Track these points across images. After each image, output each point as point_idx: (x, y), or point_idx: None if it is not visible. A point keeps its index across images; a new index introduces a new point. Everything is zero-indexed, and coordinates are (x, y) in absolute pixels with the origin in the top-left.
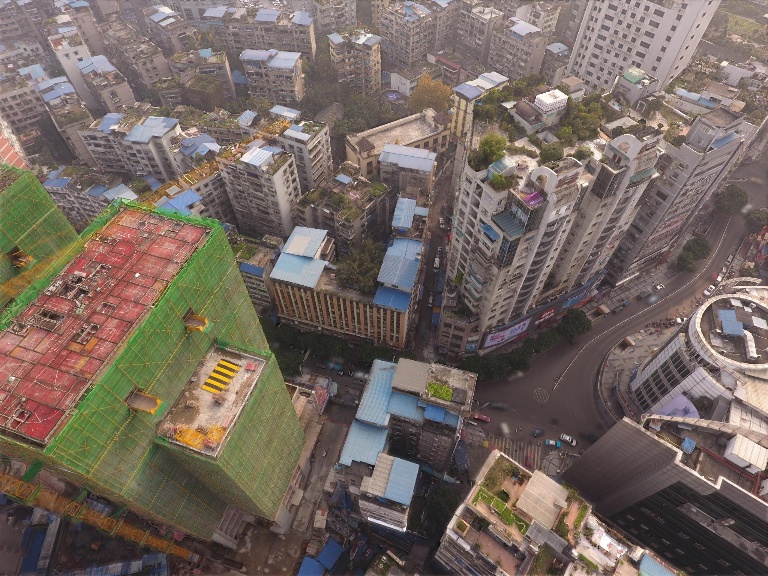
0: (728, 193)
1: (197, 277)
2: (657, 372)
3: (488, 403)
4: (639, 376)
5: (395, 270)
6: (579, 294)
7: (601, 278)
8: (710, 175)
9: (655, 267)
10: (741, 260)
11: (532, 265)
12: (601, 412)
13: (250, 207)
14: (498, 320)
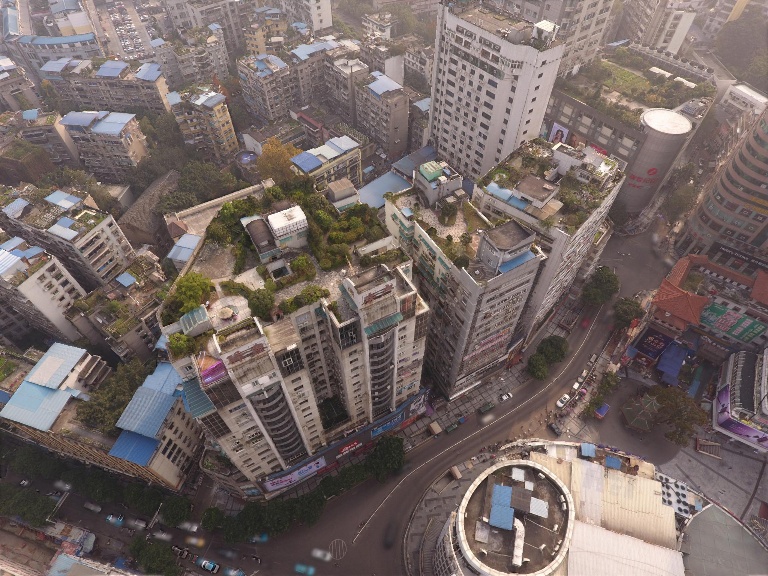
0: (597, 278)
1: None
2: None
3: (257, 571)
4: None
5: (141, 410)
6: (391, 420)
7: (421, 398)
8: (516, 294)
9: (507, 369)
10: (607, 359)
11: (269, 425)
12: (406, 572)
13: (24, 310)
14: (272, 467)
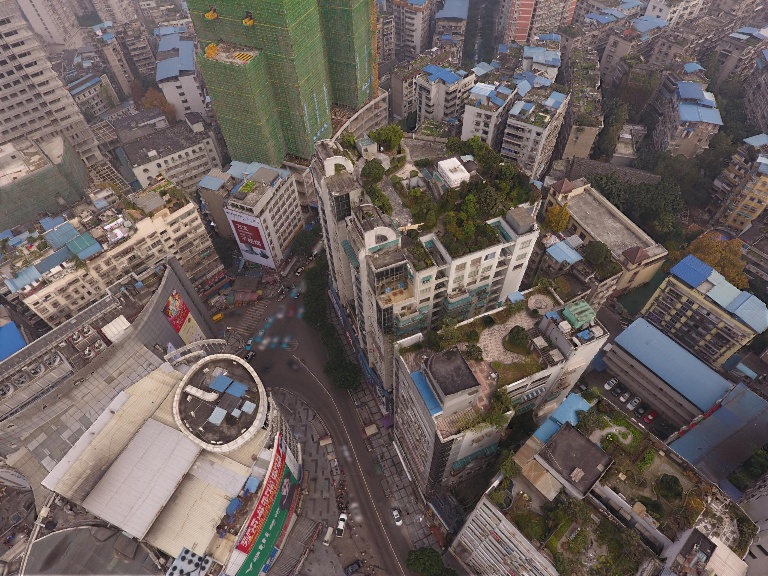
0: None
1: (259, 3)
2: None
3: None
4: None
5: None
6: None
7: None
8: None
9: None
10: None
11: None
12: None
13: None
14: None
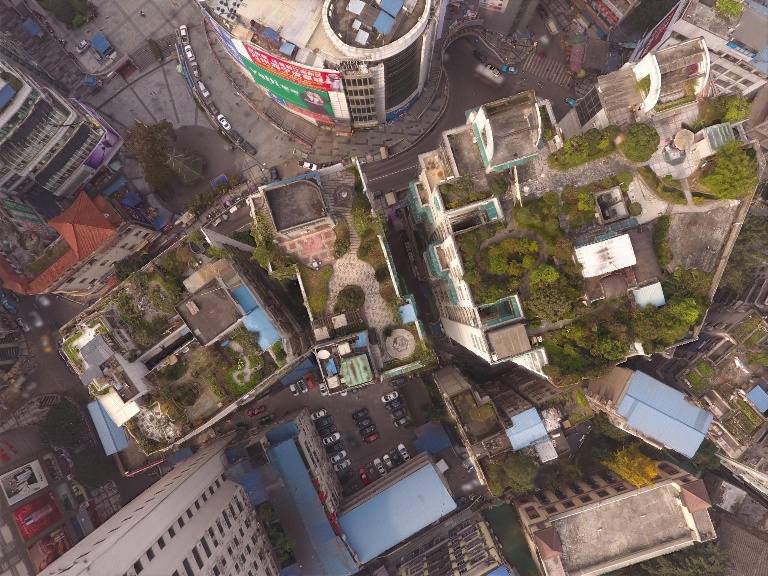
0: None
1: None
2: None
3: None
4: None
5: None
6: None
7: None
8: None
9: None
10: None
11: None
12: None
13: None
14: None
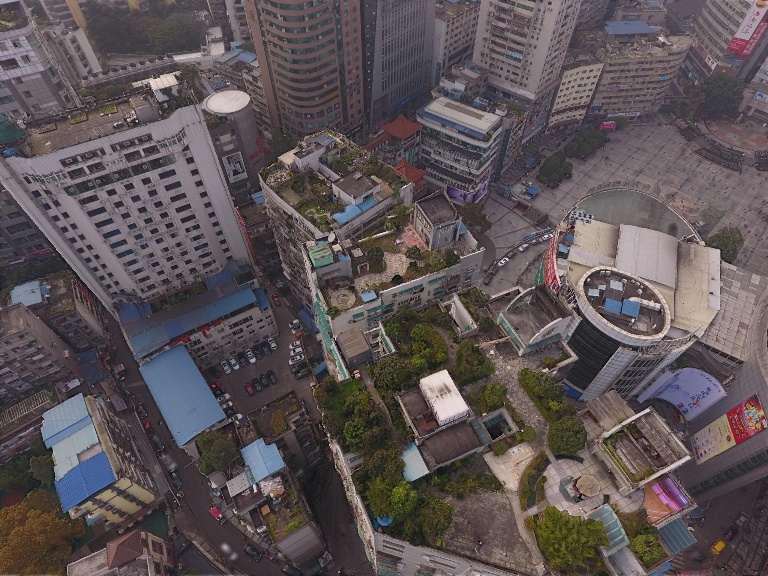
0: None
1: None
2: (622, 380)
3: None
4: (589, 391)
5: None
6: None
7: None
8: None
9: None
10: None
11: None
12: None
13: None
14: None
